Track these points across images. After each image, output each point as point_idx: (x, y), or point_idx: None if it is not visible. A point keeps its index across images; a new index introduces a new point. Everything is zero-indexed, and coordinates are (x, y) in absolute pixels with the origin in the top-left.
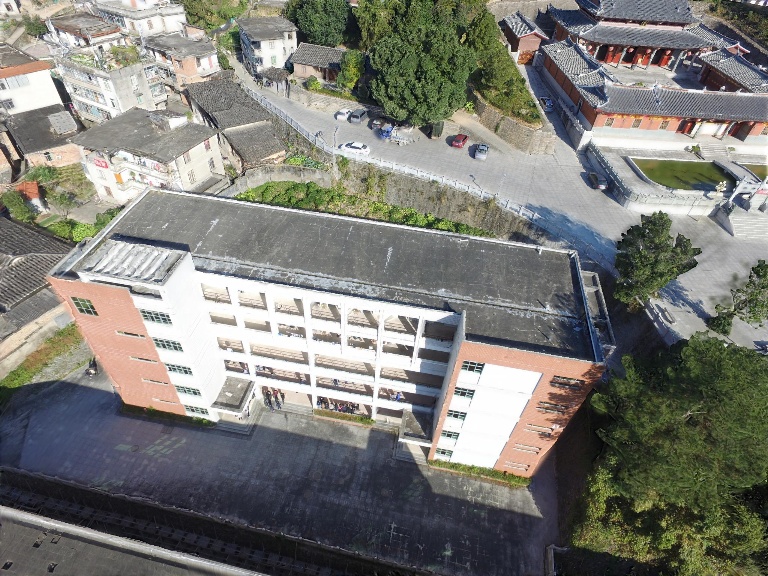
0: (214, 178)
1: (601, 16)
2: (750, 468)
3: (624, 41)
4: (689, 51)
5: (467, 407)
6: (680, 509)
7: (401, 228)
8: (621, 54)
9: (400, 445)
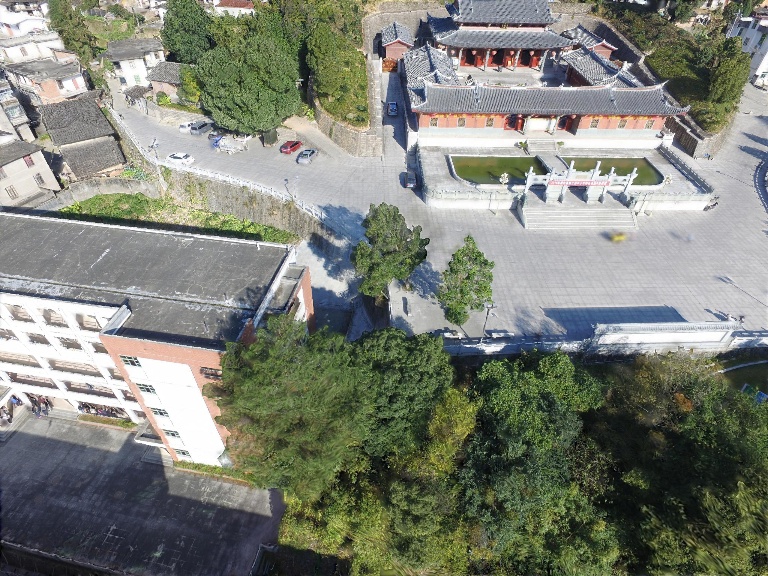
0: (42, 193)
1: (458, 21)
2: (322, 451)
3: (483, 44)
4: (553, 51)
5: (160, 404)
6: (312, 498)
7: (131, 230)
8: (486, 57)
9: (153, 447)
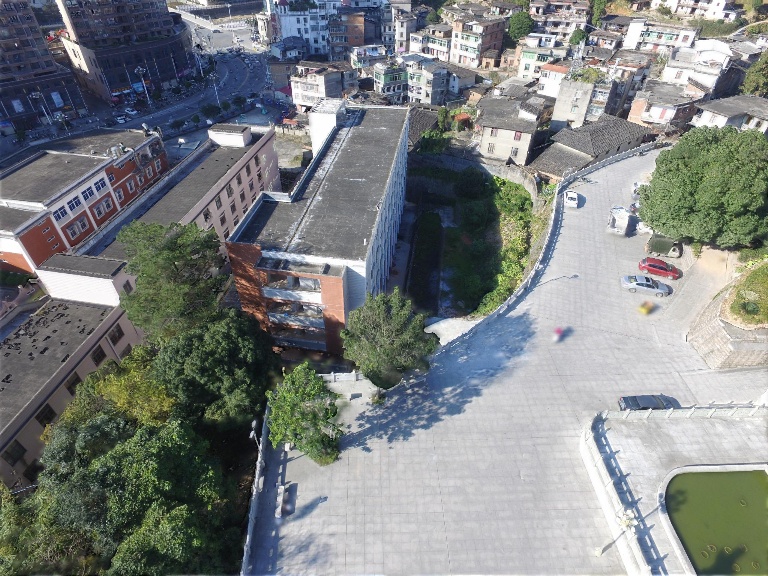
0: None
1: None
2: None
3: None
4: None
5: None
6: None
7: None
8: None
9: None
